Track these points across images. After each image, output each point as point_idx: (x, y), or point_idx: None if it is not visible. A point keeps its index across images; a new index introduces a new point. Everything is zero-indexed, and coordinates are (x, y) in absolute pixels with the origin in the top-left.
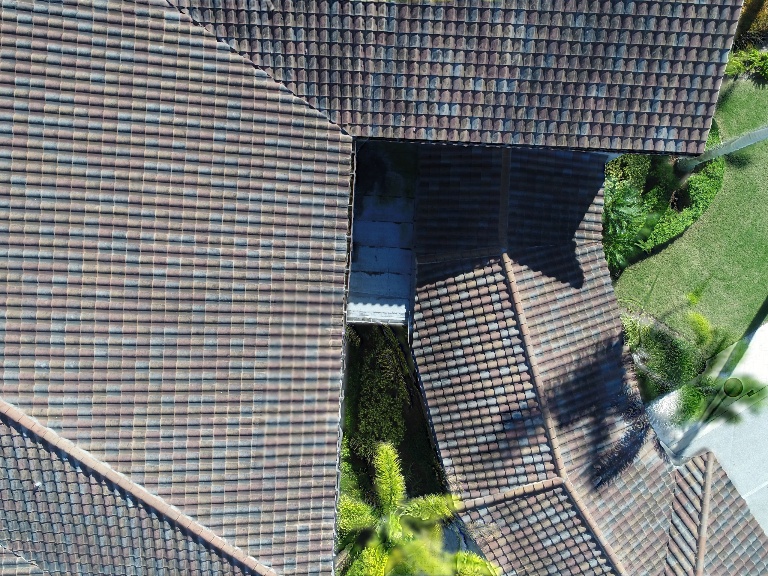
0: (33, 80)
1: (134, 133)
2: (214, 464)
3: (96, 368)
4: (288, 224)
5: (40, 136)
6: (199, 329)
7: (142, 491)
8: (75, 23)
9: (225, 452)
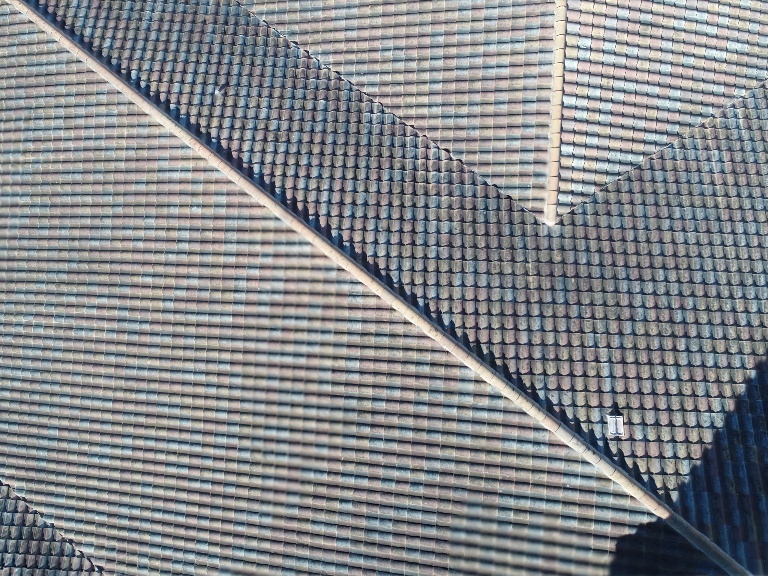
0: (198, 486)
1: (120, 435)
2: (62, 112)
3: (154, 206)
4: (2, 347)
5: (193, 432)
6: (72, 244)
7: (116, 86)
8: (164, 541)
9: (54, 124)
